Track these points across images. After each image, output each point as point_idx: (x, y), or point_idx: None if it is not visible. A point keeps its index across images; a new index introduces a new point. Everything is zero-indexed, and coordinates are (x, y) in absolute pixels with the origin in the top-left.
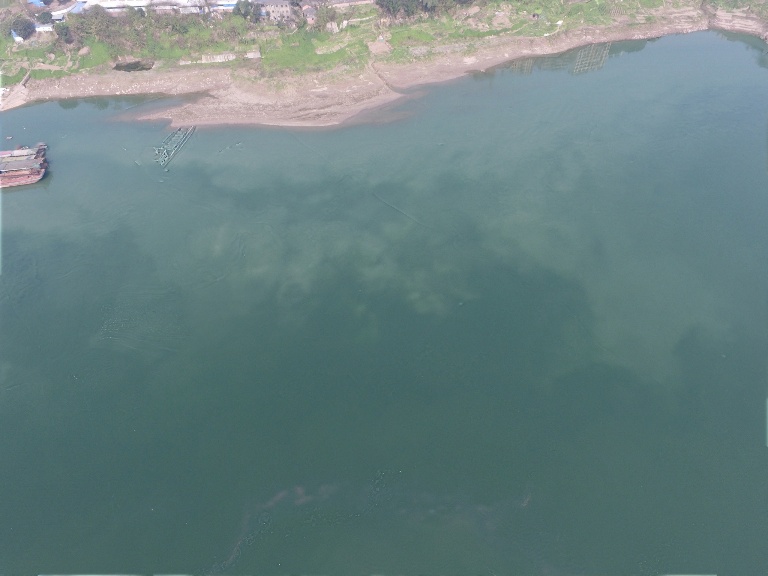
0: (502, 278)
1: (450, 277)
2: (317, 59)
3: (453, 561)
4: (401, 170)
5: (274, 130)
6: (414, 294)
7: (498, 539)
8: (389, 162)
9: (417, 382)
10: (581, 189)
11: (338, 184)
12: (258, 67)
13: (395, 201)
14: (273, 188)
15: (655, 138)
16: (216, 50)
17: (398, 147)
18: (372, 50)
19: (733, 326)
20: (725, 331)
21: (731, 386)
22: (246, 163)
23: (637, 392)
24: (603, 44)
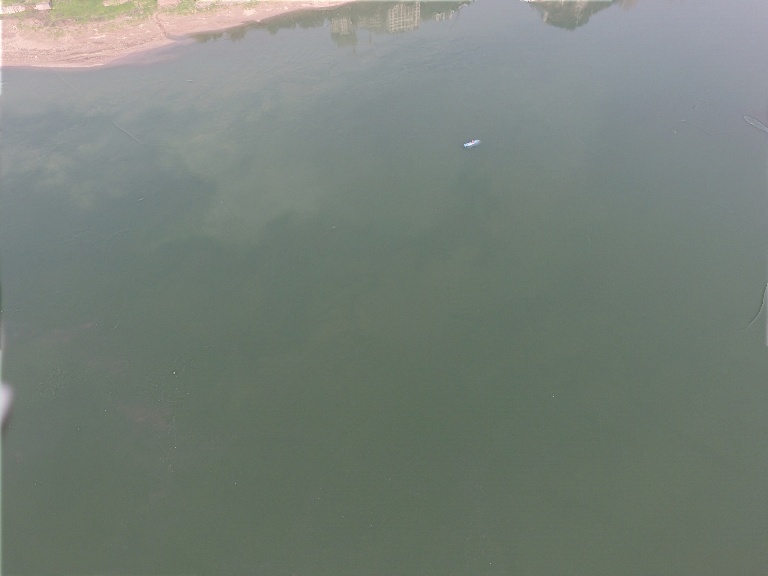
0: (178, 177)
1: (143, 181)
2: (103, 10)
3: (29, 363)
4: (144, 102)
5: (42, 71)
6: (104, 193)
7: (73, 348)
8: (137, 96)
9: (64, 251)
10: (293, 113)
11: (83, 114)
12: (44, 17)
13: (128, 126)
14: (21, 118)
15: (379, 73)
16: (6, 2)
17: (150, 83)
18: (160, 3)
19: (355, 207)
20: (347, 211)
21: (326, 247)
22: (2, 98)
23: (247, 253)
24: (411, 4)
